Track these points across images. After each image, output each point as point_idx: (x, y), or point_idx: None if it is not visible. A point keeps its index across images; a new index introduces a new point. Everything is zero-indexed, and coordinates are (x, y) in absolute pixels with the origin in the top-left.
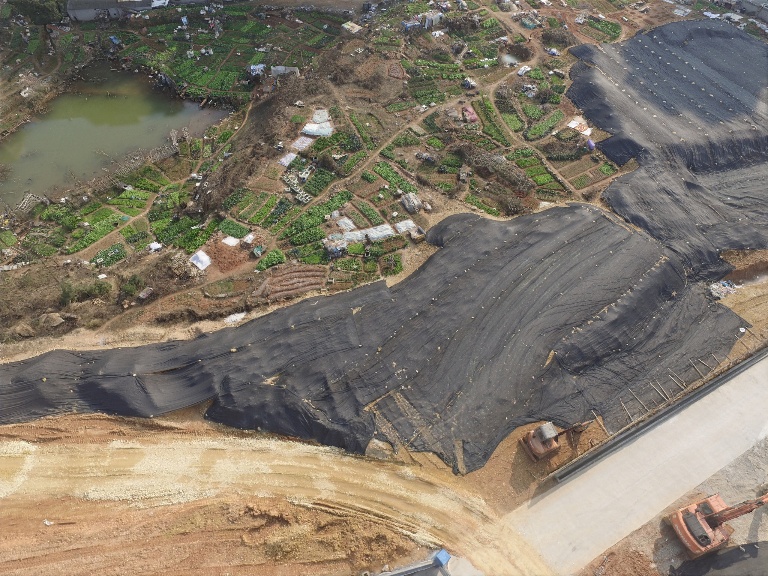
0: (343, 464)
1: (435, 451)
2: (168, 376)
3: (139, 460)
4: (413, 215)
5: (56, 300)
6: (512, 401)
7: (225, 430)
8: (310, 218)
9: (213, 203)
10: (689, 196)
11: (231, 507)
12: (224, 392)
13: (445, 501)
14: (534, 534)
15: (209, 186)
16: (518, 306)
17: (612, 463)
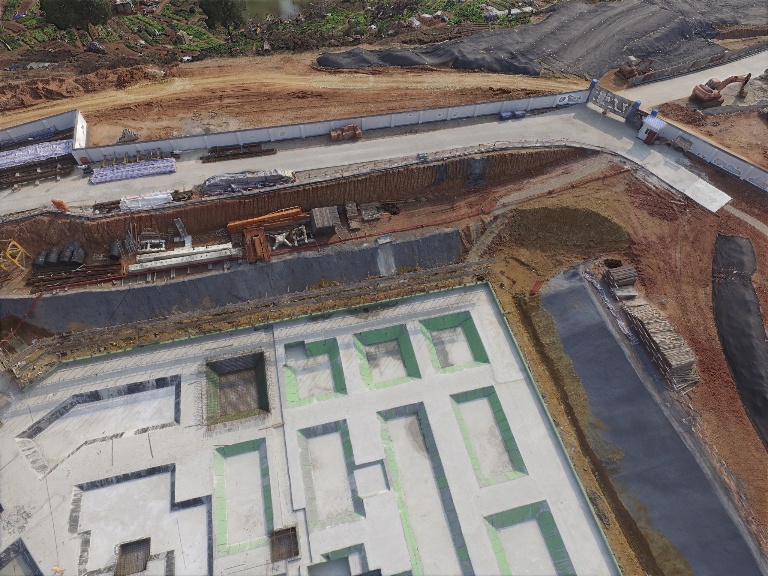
0: (529, 80)
1: (574, 74)
2: (425, 55)
3: (426, 79)
4: (530, 6)
5: (340, 36)
6: (609, 61)
7: (464, 71)
8: (470, 6)
9: (406, 3)
10: (693, 0)
11: (482, 88)
12: (461, 55)
13: (584, 88)
14: (629, 97)
15: (391, 4)
16: (603, 32)
17: (662, 84)
